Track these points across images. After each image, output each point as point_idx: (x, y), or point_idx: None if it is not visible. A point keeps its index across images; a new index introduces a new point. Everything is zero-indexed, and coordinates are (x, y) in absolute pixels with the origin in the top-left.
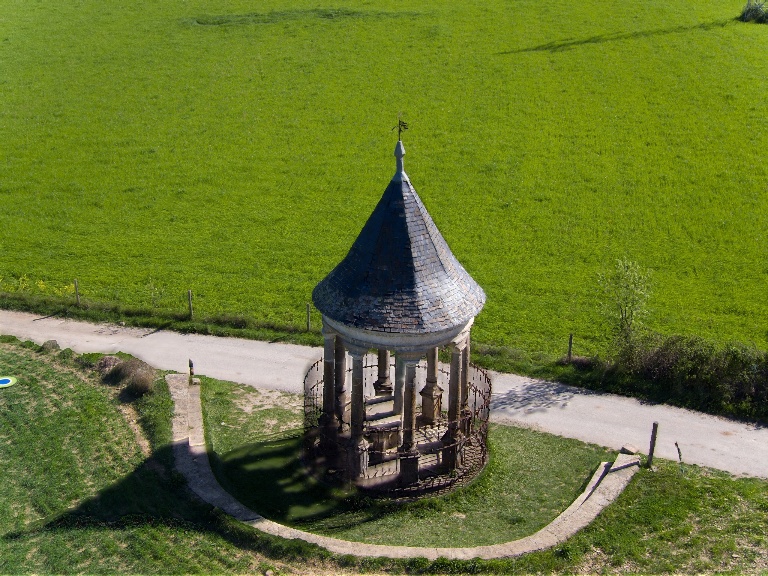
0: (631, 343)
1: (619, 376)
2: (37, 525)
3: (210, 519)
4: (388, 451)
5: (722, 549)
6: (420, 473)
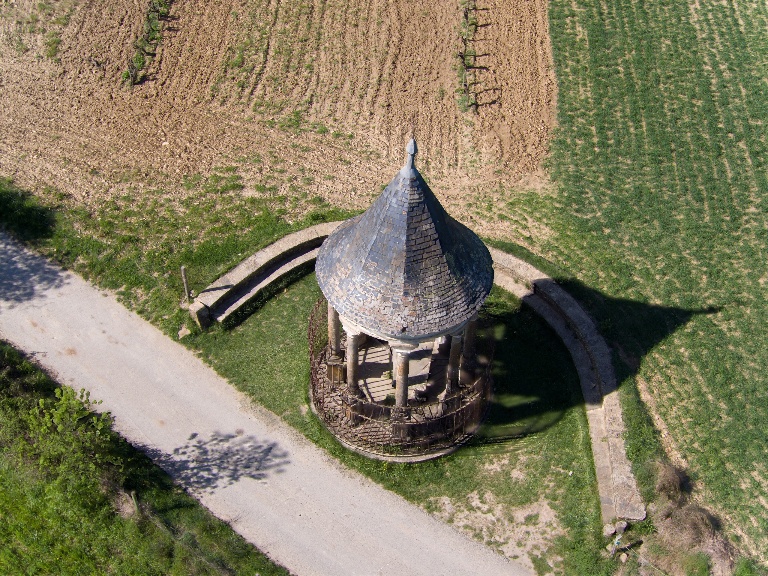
0: None
1: None
2: (710, 305)
3: None
4: None
5: (202, 209)
6: None
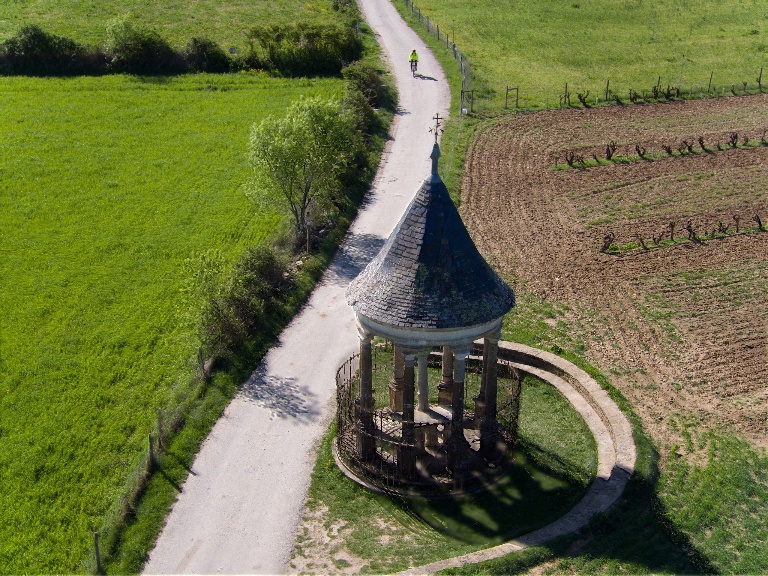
0: (228, 318)
1: None
2: None
3: (645, 487)
4: (440, 442)
5: None
6: (467, 424)
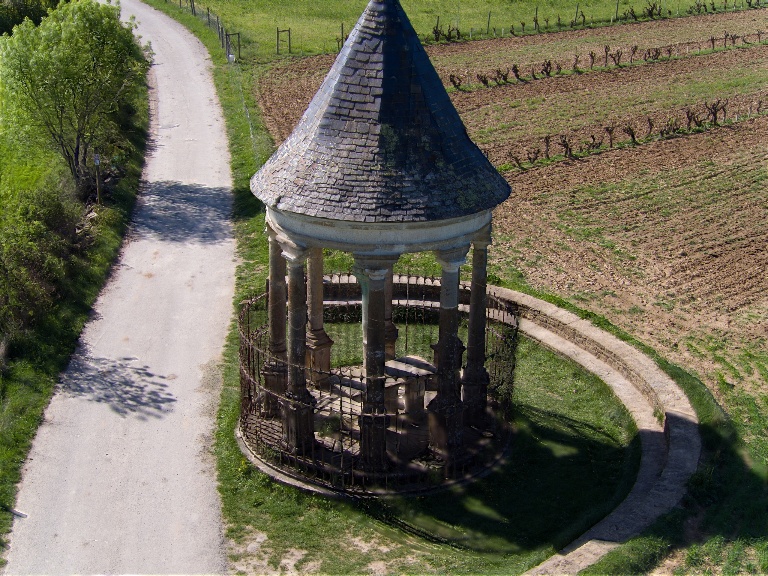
0: (21, 282)
1: (55, 321)
2: None
3: None
4: None
5: None
6: None
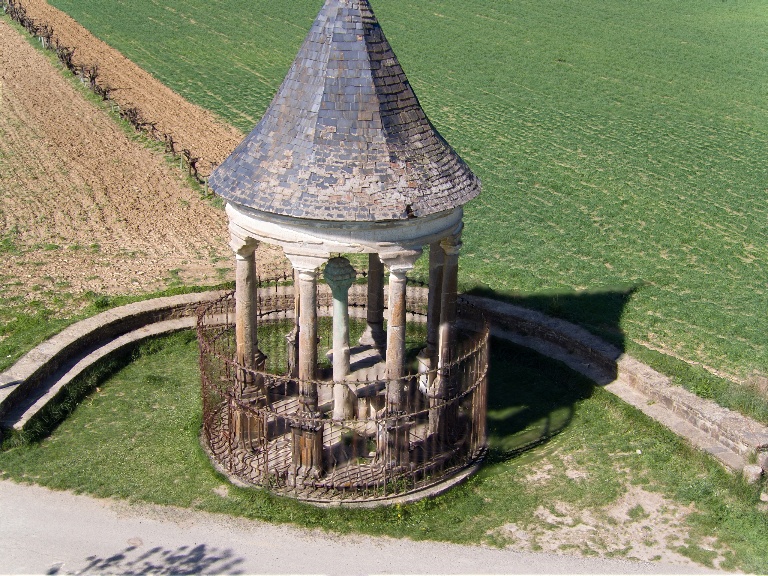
0: None
1: None
2: None
3: None
4: None
5: None
6: (292, 389)
